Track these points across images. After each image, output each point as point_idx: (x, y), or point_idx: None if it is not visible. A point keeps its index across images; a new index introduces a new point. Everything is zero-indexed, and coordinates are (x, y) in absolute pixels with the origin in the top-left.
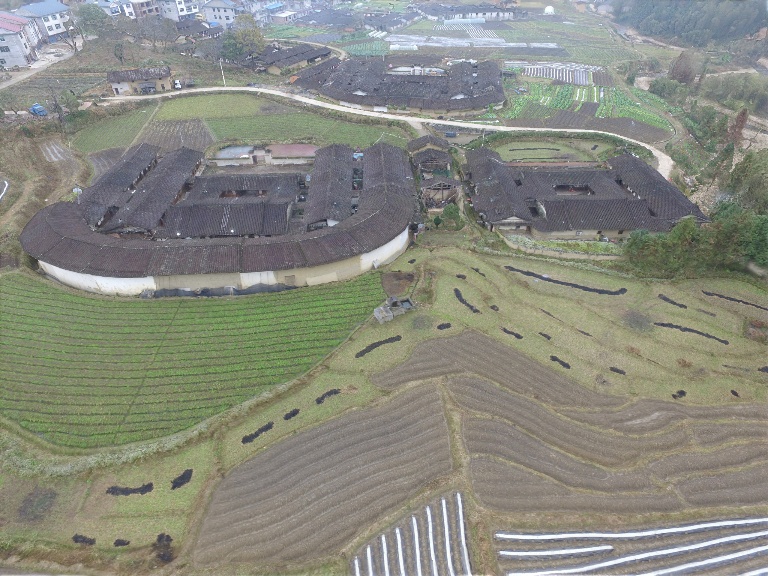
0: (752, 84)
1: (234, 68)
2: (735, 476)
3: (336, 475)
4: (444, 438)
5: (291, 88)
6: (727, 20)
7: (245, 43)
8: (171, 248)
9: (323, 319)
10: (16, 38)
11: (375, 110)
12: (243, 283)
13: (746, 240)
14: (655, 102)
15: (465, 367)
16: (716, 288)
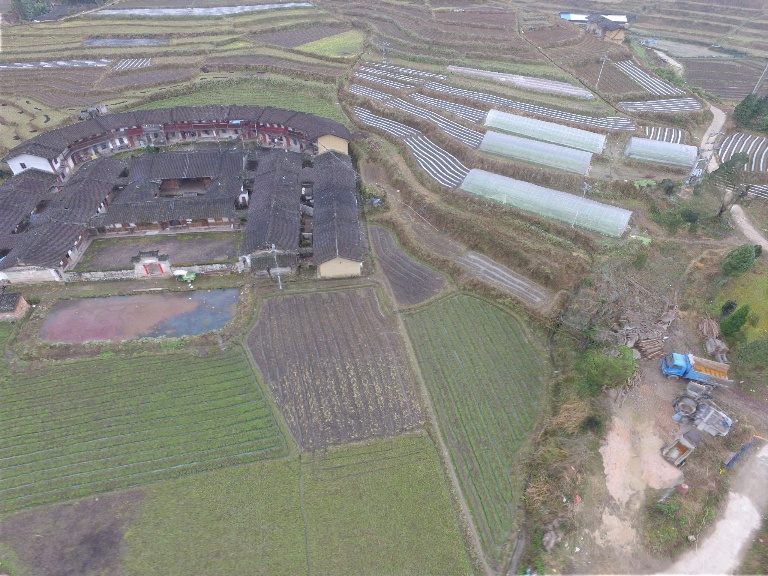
0: None
1: None
2: (14, 74)
3: None
4: None
5: None
6: None
7: None
8: (219, 106)
9: None
10: None
11: None
12: None
13: None
14: None
15: None
16: None
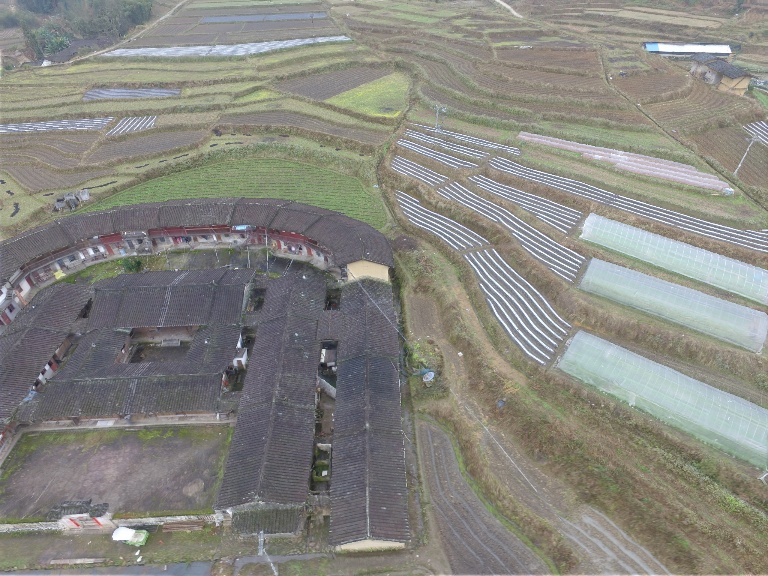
0: None
1: None
2: None
3: None
4: None
5: None
6: None
7: None
8: (220, 203)
9: None
10: None
11: None
12: None
13: None
14: None
15: None
16: None
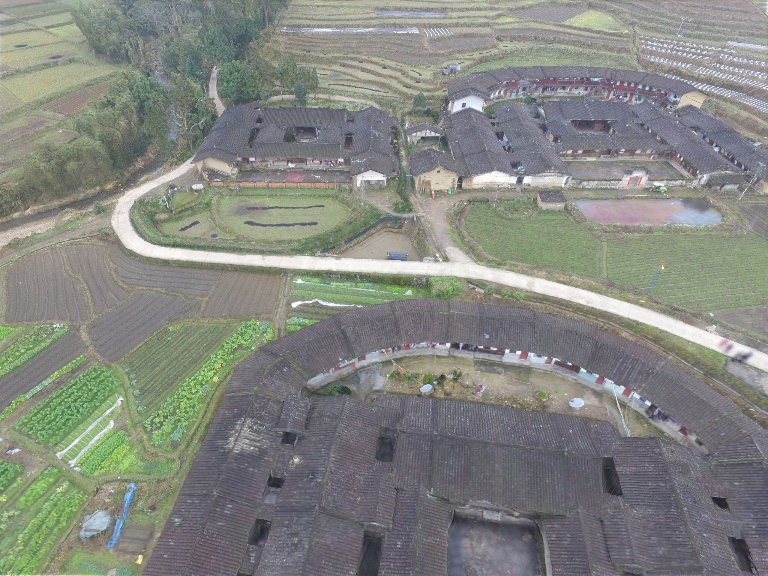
0: None
1: None
2: None
3: None
4: None
5: None
6: None
7: None
8: None
9: None
10: None
11: None
12: None
13: None
14: None
15: None
16: None
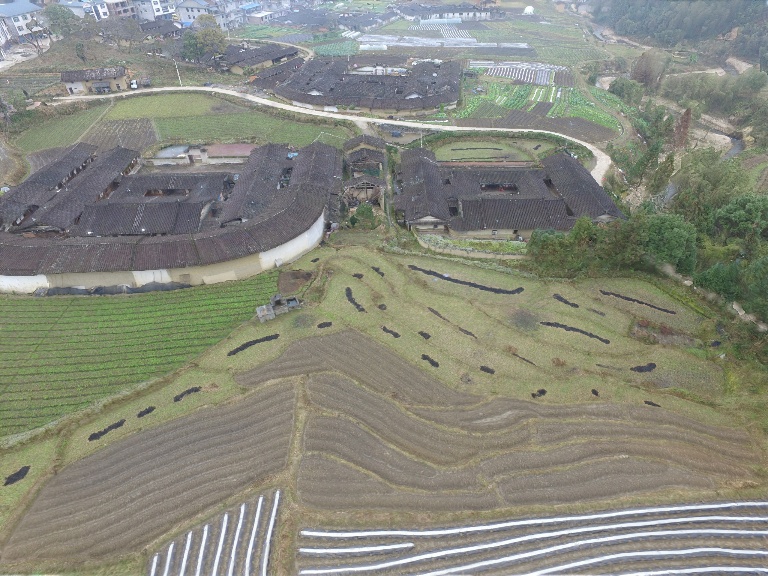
0: (708, 84)
1: (196, 68)
2: (561, 475)
3: (168, 472)
4: (286, 436)
5: (246, 88)
6: (699, 20)
7: (205, 43)
8: (65, 246)
9: (209, 317)
10: None
11: (326, 110)
12: (137, 281)
13: (643, 239)
14: (611, 102)
15: (333, 365)
16: (615, 288)
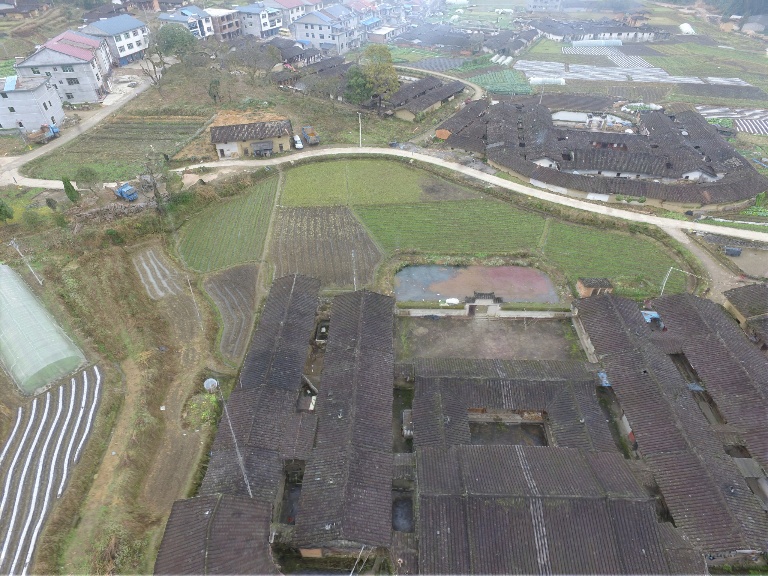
0: None
1: None
2: None
3: None
4: None
5: (452, 153)
6: None
7: (377, 83)
8: None
9: None
10: (87, 68)
11: (589, 197)
12: None
13: None
14: None
15: None
16: None
